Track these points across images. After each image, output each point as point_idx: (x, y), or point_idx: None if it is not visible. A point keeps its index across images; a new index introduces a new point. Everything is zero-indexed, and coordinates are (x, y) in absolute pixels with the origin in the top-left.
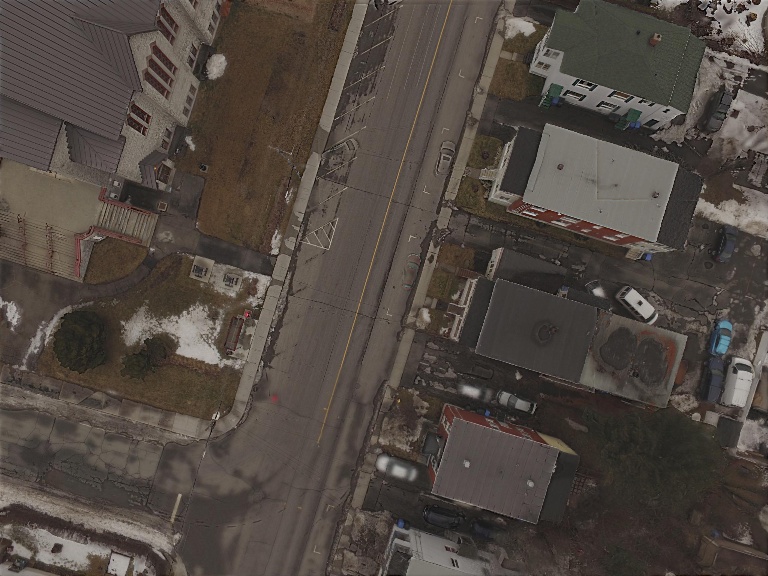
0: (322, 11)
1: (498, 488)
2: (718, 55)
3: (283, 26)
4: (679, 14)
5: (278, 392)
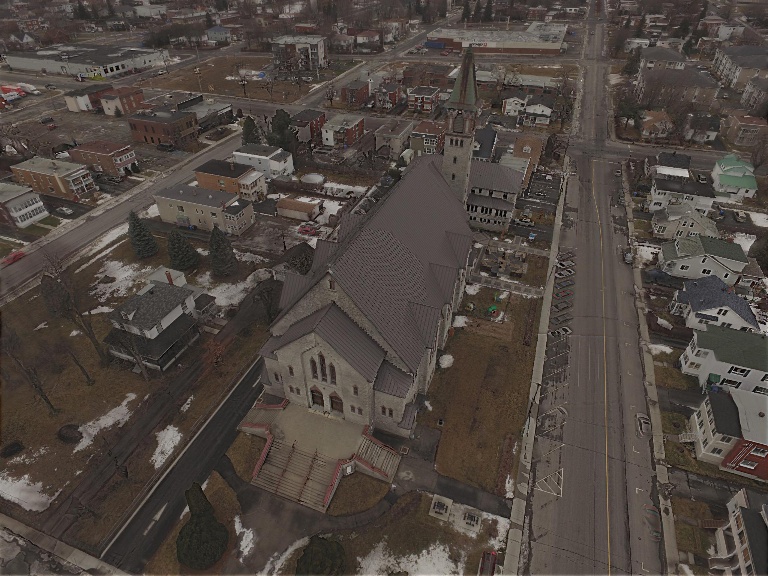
0: (517, 336)
1: None
2: None
3: (491, 342)
4: None
5: None
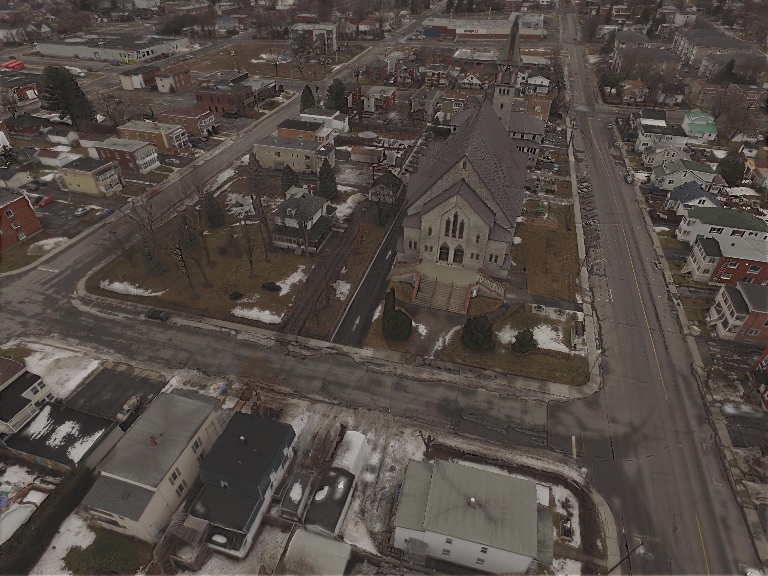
0: (561, 226)
1: None
2: None
3: (544, 229)
4: None
5: (619, 369)
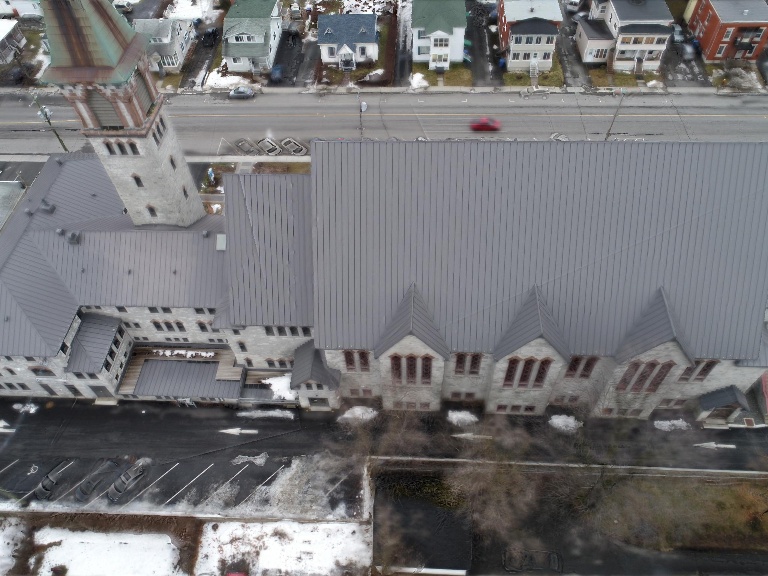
0: None
1: (747, 2)
2: (400, 5)
3: None
4: (379, 23)
5: None
